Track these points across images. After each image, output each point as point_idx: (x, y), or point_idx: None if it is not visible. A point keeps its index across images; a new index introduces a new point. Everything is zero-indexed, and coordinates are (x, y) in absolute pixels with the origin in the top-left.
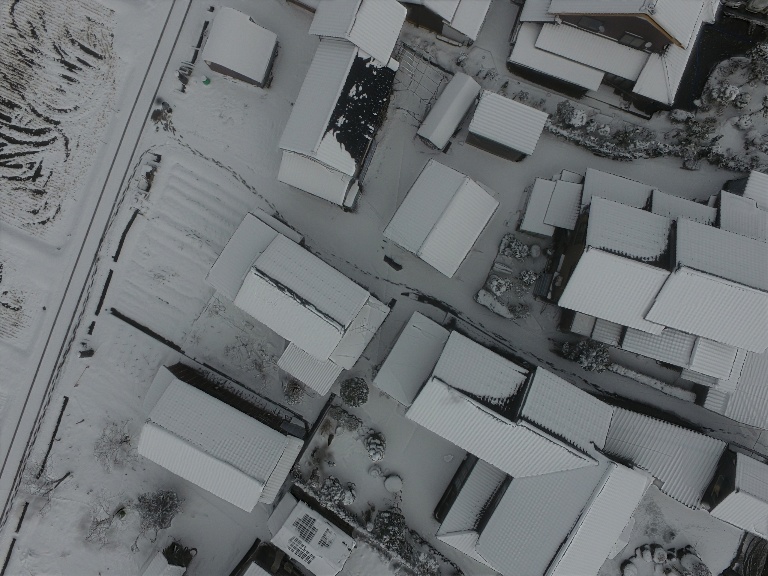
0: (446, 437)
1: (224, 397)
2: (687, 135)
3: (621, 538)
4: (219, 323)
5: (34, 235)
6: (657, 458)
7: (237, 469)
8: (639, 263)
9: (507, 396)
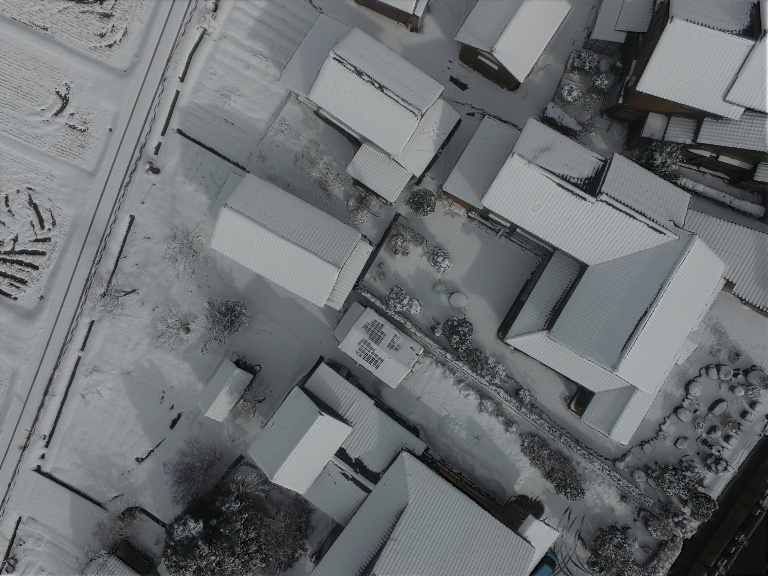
0: (522, 224)
1: None
2: None
3: (692, 340)
4: (285, 142)
5: (101, 58)
6: (729, 259)
7: (313, 254)
8: (723, 33)
9: (585, 177)
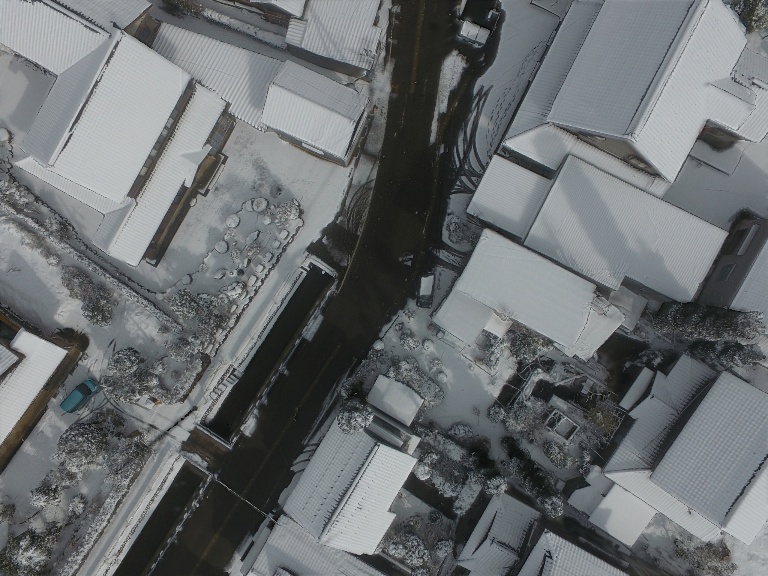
0: None
1: None
2: None
3: (191, 160)
4: None
5: None
6: (224, 79)
7: None
8: None
9: None
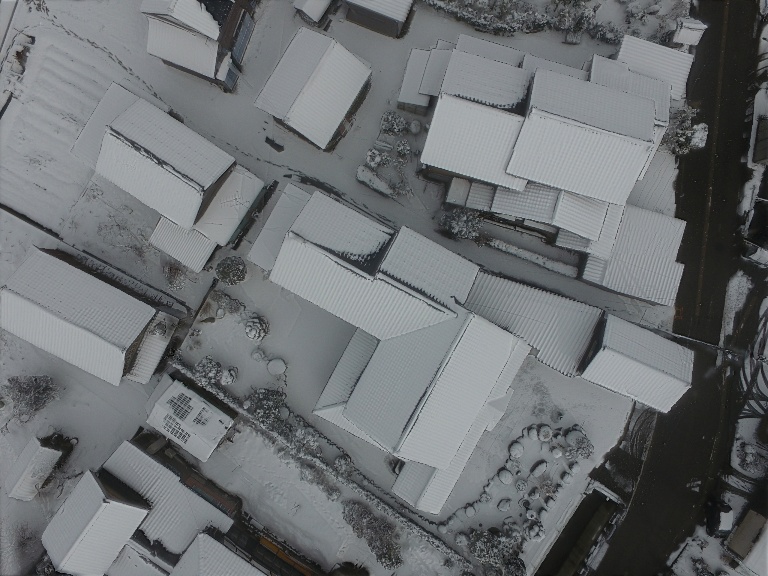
0: (311, 300)
1: (98, 278)
2: (564, 4)
3: (498, 407)
4: (97, 208)
5: None
6: (532, 326)
7: (96, 335)
8: (493, 109)
9: (368, 253)
